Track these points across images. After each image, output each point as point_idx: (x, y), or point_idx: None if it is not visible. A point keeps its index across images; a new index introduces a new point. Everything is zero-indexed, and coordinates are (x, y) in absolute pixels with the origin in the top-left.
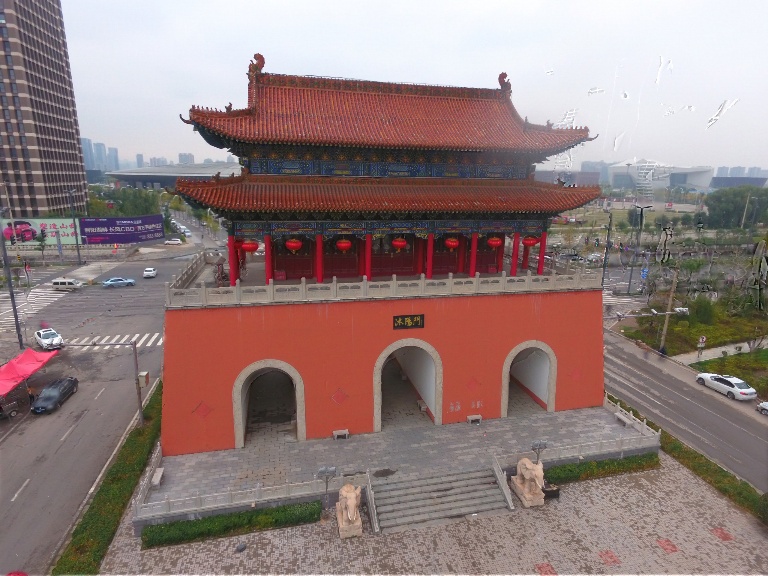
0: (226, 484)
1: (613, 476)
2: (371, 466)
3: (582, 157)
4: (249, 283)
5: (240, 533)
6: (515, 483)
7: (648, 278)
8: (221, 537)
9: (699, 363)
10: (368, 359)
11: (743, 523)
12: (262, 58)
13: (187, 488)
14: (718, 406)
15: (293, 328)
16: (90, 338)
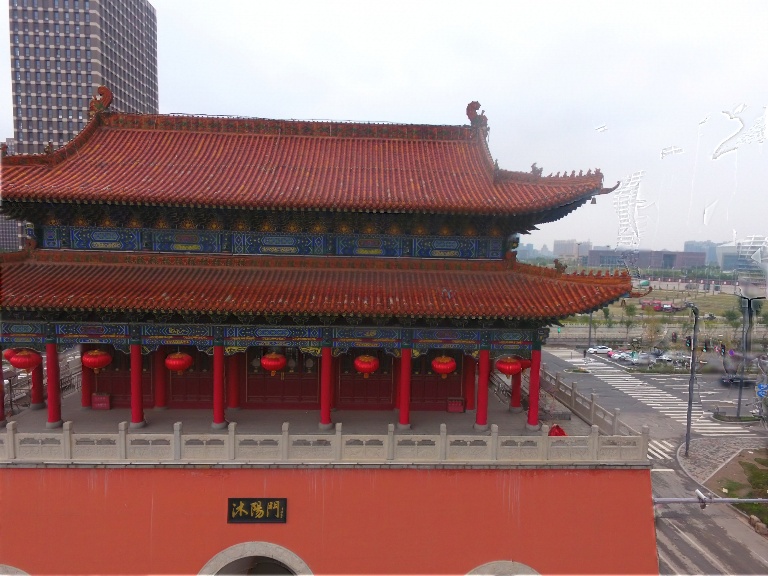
0: None
1: None
2: None
3: (654, 231)
4: (45, 413)
5: None
6: None
7: (766, 403)
8: None
9: None
10: (178, 575)
11: None
12: (109, 92)
13: None
14: None
15: (44, 510)
16: None
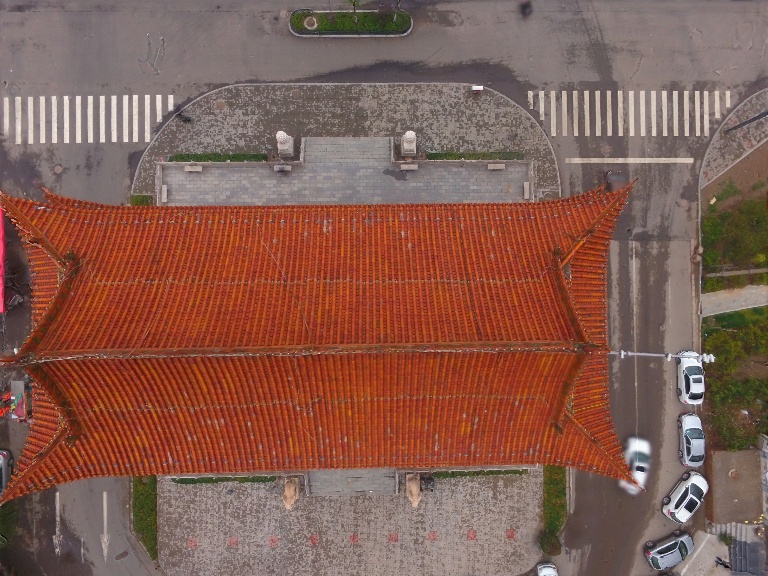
0: None
1: None
2: None
3: None
4: None
5: (228, 481)
6: None
7: None
8: None
9: (719, 317)
10: None
11: (532, 529)
12: None
13: None
14: (653, 400)
15: None
16: (10, 101)
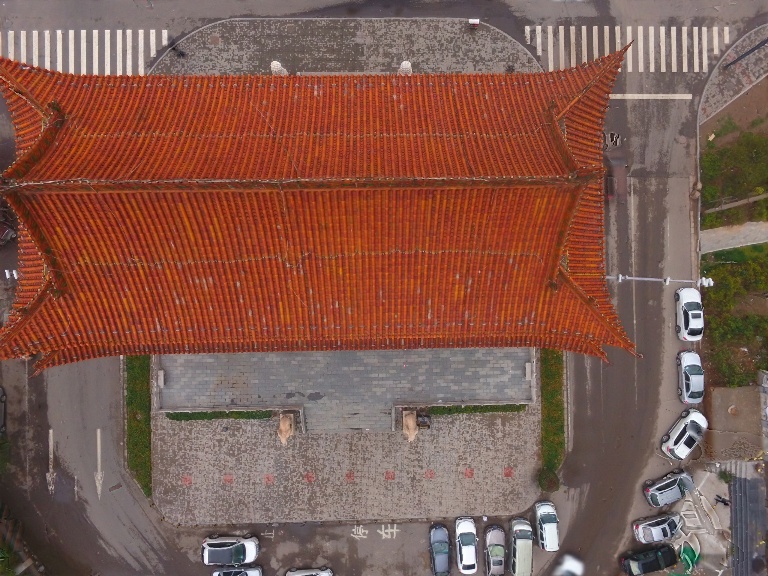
0: (208, 389)
1: (481, 413)
2: (307, 388)
3: None
4: None
5: (223, 418)
6: (403, 417)
7: None
8: (213, 418)
9: (718, 254)
10: None
11: (530, 467)
12: None
13: (183, 388)
14: (652, 338)
15: None
16: (2, 35)
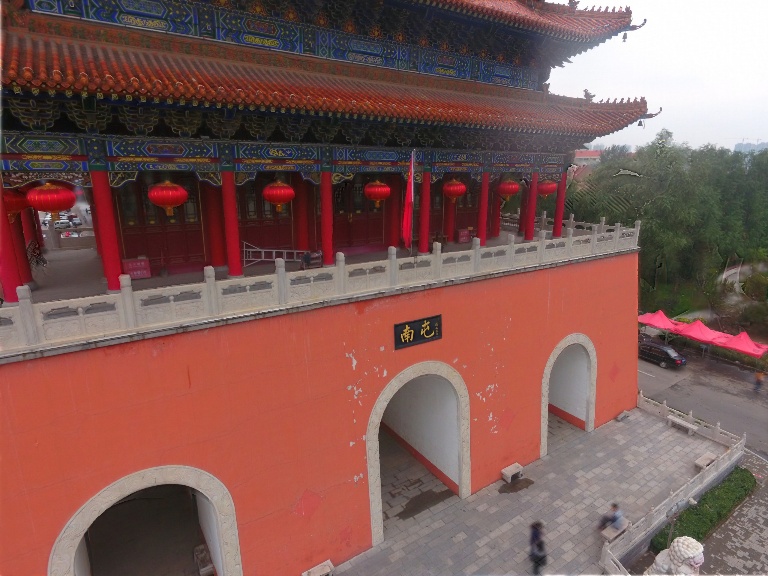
0: None
1: None
2: None
3: None
4: None
5: None
6: None
7: None
8: None
9: None
10: None
11: None
12: None
13: None
14: None
15: None
16: None
